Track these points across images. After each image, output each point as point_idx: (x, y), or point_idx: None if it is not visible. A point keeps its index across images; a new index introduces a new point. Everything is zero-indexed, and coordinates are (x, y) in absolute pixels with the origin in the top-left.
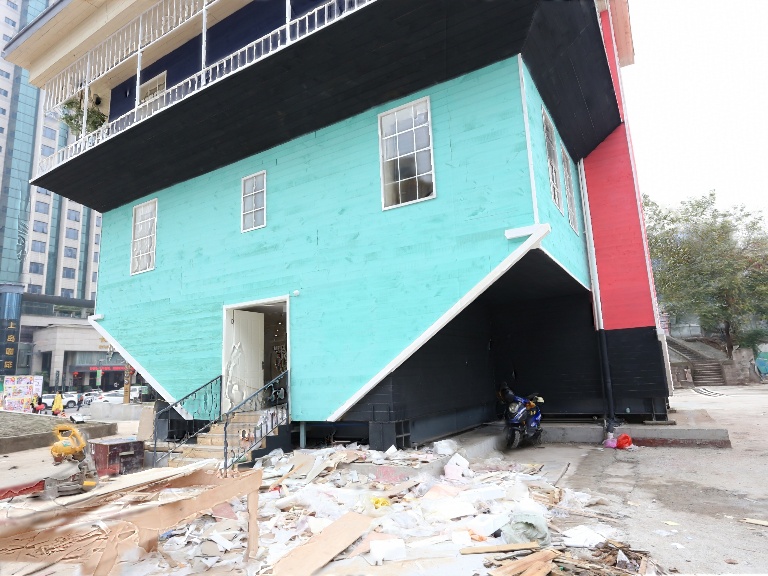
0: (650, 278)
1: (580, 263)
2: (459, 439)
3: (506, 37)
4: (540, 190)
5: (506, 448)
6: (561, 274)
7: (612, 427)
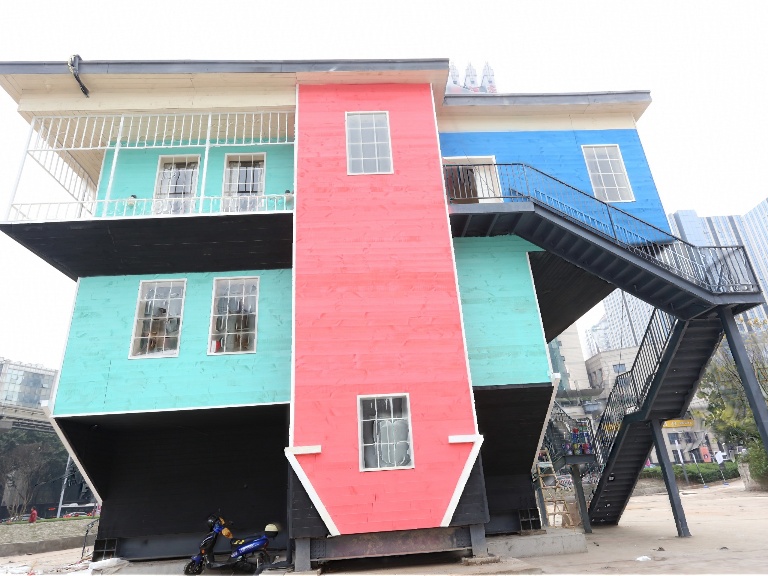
0: (291, 384)
1: (249, 382)
2: (185, 560)
3: (72, 273)
4: (85, 366)
5: (218, 575)
6: (166, 412)
7: (258, 569)
